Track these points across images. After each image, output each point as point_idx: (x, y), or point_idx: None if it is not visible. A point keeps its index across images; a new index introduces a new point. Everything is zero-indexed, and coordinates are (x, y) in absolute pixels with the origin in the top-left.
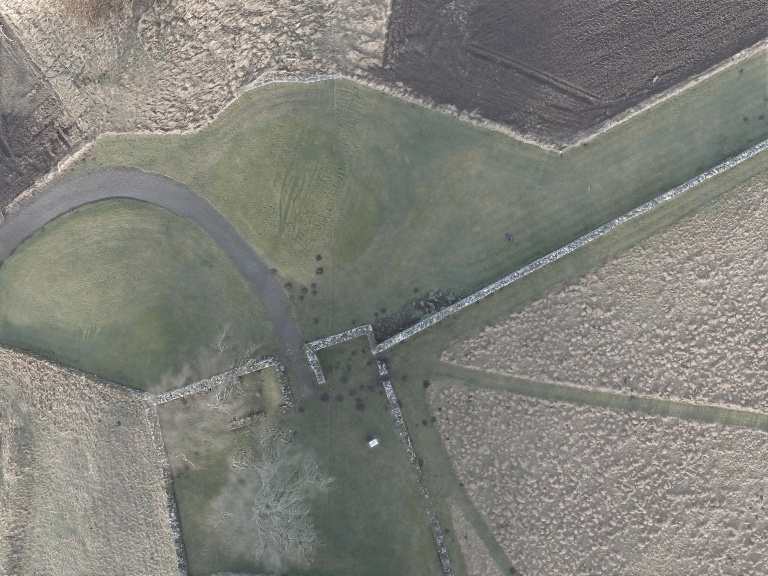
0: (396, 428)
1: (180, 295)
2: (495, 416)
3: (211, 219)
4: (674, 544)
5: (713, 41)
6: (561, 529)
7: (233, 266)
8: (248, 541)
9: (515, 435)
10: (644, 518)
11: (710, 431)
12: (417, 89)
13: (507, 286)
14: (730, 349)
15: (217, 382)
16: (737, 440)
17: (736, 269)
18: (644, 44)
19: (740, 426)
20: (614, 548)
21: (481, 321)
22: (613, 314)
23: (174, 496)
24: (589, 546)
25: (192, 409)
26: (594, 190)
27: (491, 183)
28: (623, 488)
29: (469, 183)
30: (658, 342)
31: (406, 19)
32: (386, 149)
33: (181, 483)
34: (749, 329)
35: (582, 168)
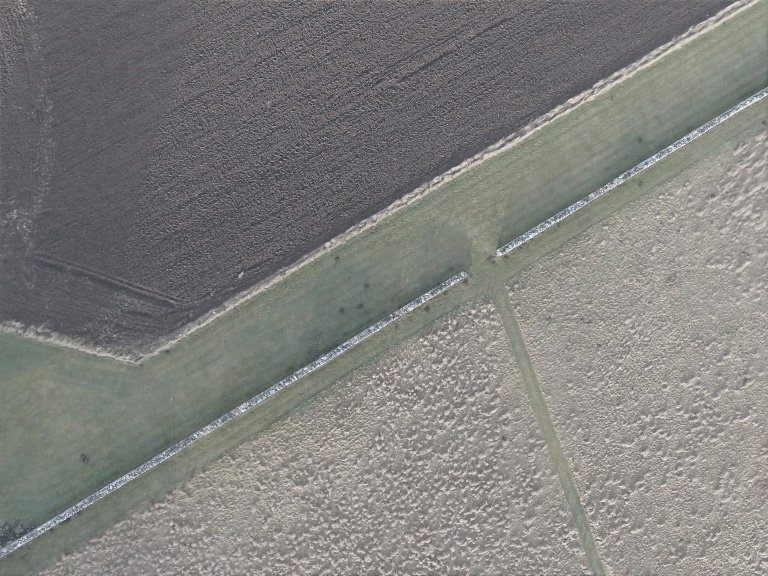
0: None
1: None
2: None
3: None
4: None
5: (303, 229)
6: None
7: None
8: None
9: None
10: None
11: None
12: None
13: (86, 510)
14: (334, 556)
15: None
16: None
17: (338, 471)
18: (226, 239)
19: None
20: None
21: (58, 549)
22: (205, 529)
23: None
24: None
25: None
26: (177, 400)
27: (64, 401)
28: None
29: (40, 403)
30: (255, 556)
31: None
32: None
33: None
34: (354, 533)
35: (164, 377)
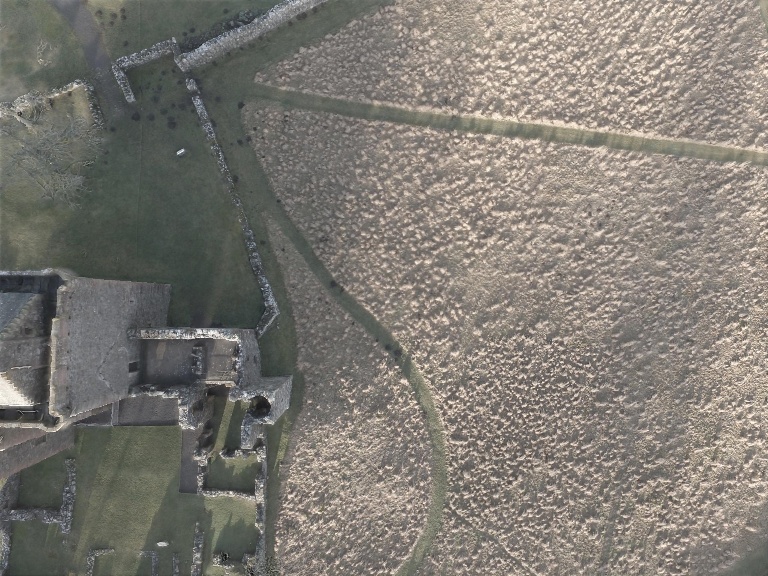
0: (207, 142)
1: None
2: (312, 135)
3: None
4: (501, 261)
5: None
6: (382, 243)
7: (46, 1)
8: (59, 253)
9: (333, 153)
10: (469, 234)
11: (534, 148)
12: None
13: (321, 8)
14: (552, 66)
15: (23, 100)
16: (562, 156)
17: None
18: None
19: (565, 143)
20: (438, 263)
21: (295, 43)
22: (431, 34)
23: None
24: (412, 261)
25: None
26: None
27: None
28: (446, 205)
29: None
30: (478, 61)
31: None
32: None
33: None
34: (571, 46)
35: None
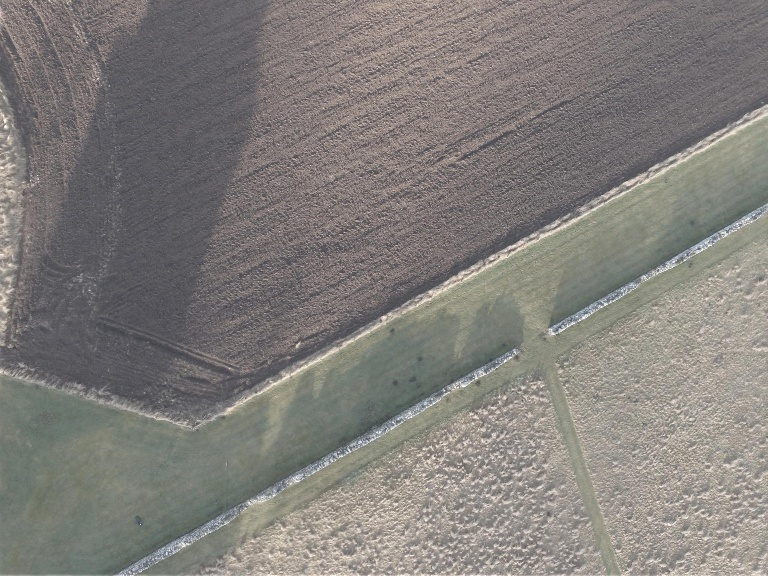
0: None
1: None
2: None
3: None
4: None
5: (360, 302)
6: None
7: None
8: None
9: None
10: None
11: None
12: (43, 367)
13: None
14: None
15: None
16: None
17: (385, 541)
18: (285, 309)
19: None
20: None
21: None
22: None
23: None
24: None
25: None
26: (231, 466)
27: (121, 463)
28: None
29: (98, 464)
30: None
31: (29, 296)
32: (5, 435)
33: None
34: None
35: (219, 442)
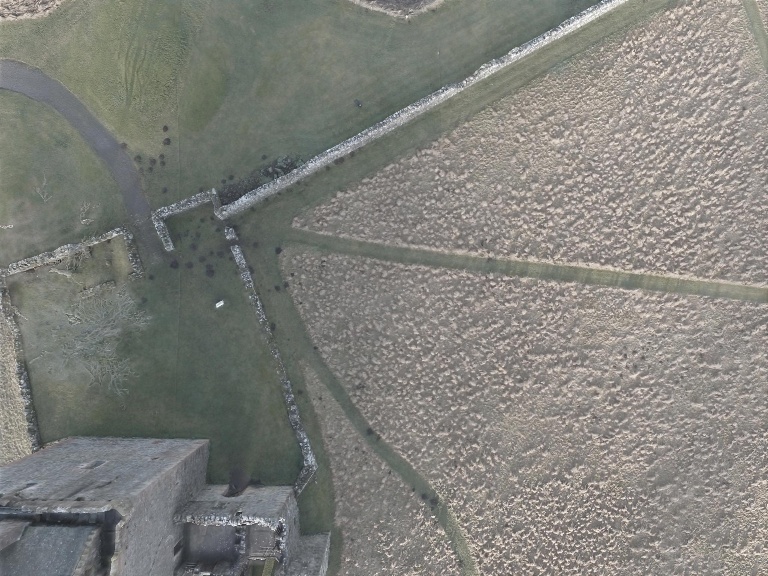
0: (245, 291)
1: (34, 175)
2: (349, 280)
3: (64, 100)
4: (537, 404)
5: None
6: (418, 390)
7: (85, 144)
8: (98, 405)
9: (370, 298)
10: (505, 378)
11: (570, 290)
12: None
13: (358, 152)
14: (588, 208)
15: (64, 251)
16: (598, 299)
17: (591, 129)
18: None
19: (601, 285)
20: (474, 408)
21: (333, 187)
22: (467, 177)
23: (25, 365)
24: (448, 406)
25: (42, 280)
26: (443, 54)
27: (339, 51)
28: (482, 349)
29: (316, 52)
30: (514, 203)
31: None
32: (230, 20)
33: (32, 352)
34: (606, 188)
35: (430, 33)
